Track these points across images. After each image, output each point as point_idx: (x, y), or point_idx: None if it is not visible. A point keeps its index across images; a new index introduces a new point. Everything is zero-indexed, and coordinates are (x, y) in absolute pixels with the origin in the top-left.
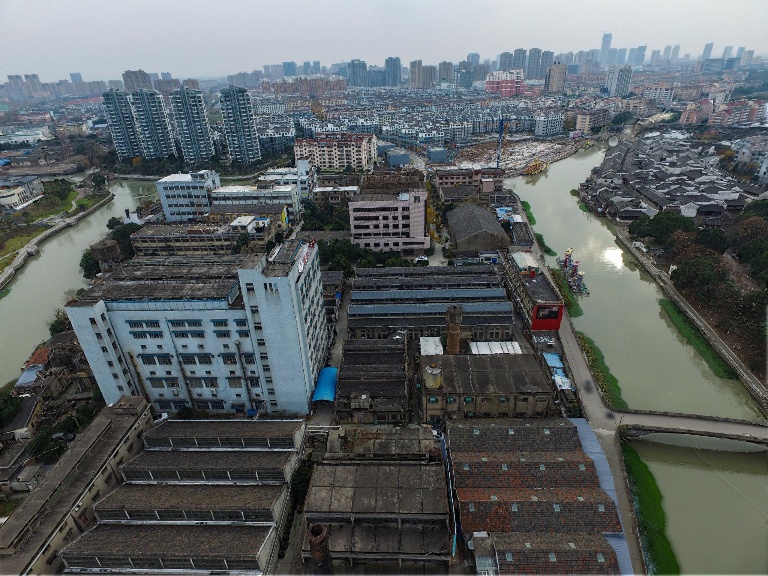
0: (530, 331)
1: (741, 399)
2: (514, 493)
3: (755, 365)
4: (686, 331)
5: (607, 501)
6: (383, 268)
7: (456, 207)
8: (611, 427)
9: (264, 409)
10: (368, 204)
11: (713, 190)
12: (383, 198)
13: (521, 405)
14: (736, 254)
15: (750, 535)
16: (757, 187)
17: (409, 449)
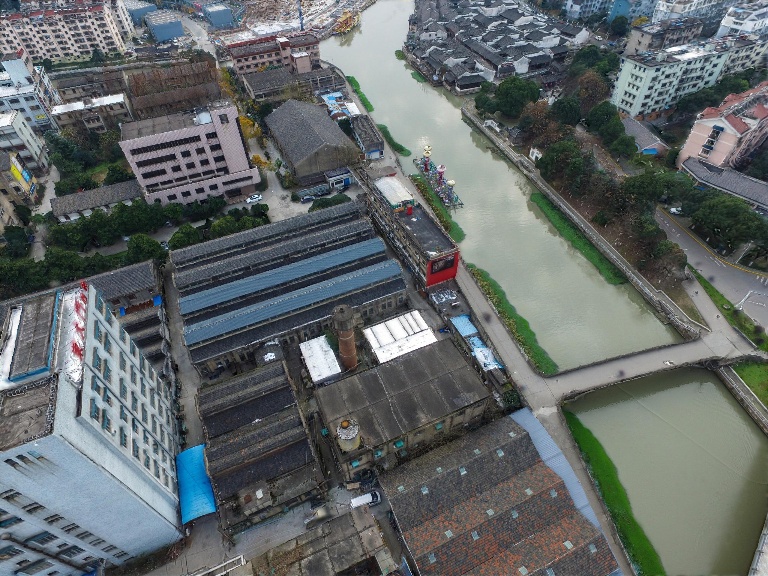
0: (425, 288)
1: (623, 293)
2: (498, 571)
3: (643, 266)
4: (567, 232)
5: (596, 537)
6: (211, 243)
7: (272, 103)
8: (550, 402)
9: (108, 564)
10: (151, 139)
11: (537, 36)
12: (172, 124)
13: (458, 419)
14: (585, 122)
15: (694, 476)
16: (572, 26)
17: (350, 557)
